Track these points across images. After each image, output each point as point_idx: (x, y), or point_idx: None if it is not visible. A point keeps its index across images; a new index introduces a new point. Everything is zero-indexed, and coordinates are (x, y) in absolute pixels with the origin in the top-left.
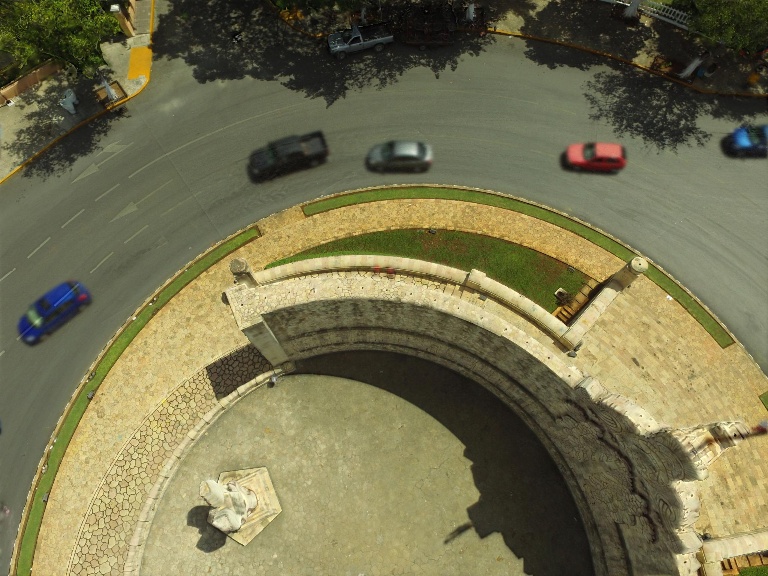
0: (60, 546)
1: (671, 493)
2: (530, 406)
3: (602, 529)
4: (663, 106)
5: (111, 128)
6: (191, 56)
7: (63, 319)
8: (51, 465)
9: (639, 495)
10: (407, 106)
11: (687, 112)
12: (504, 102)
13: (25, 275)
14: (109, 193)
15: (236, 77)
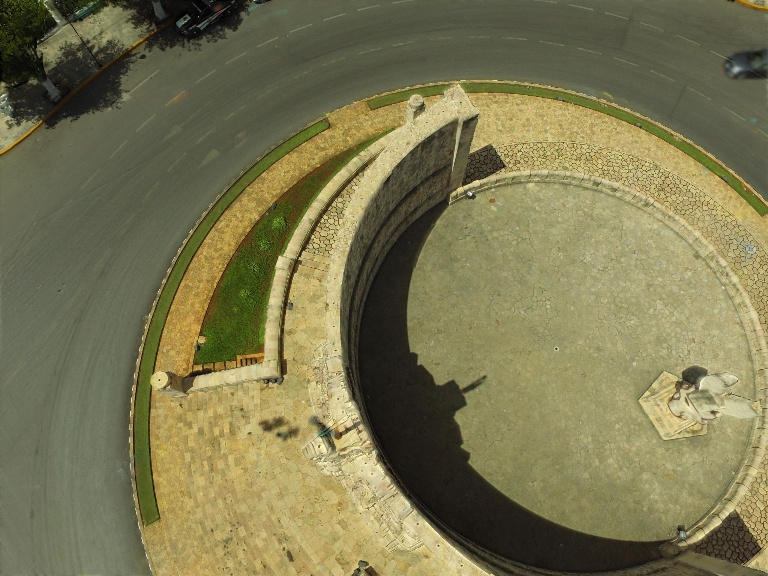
0: None
1: None
2: None
3: None
4: None
5: None
6: None
7: None
8: None
9: None
10: None
11: None
12: None
13: None
14: None
15: None
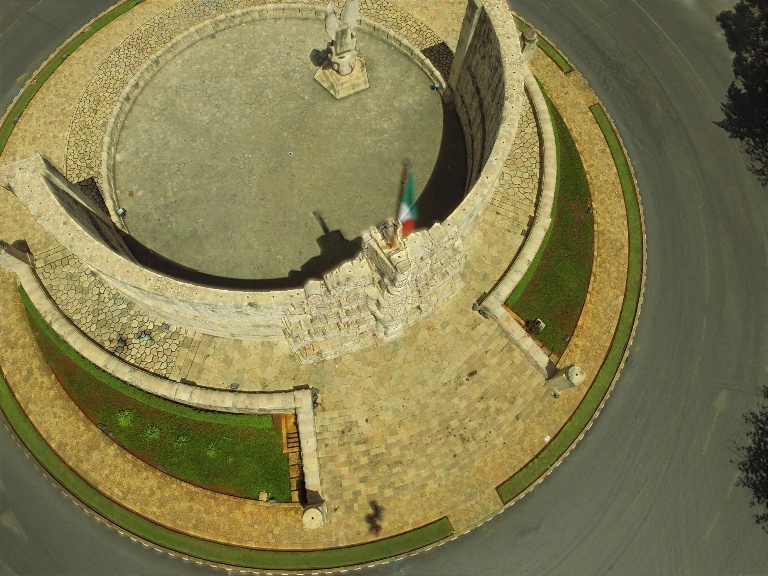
0: None
1: None
2: None
3: None
4: None
5: None
6: (746, 7)
7: None
8: None
9: None
10: (734, 194)
11: None
12: (764, 293)
13: None
14: None
15: (731, 44)
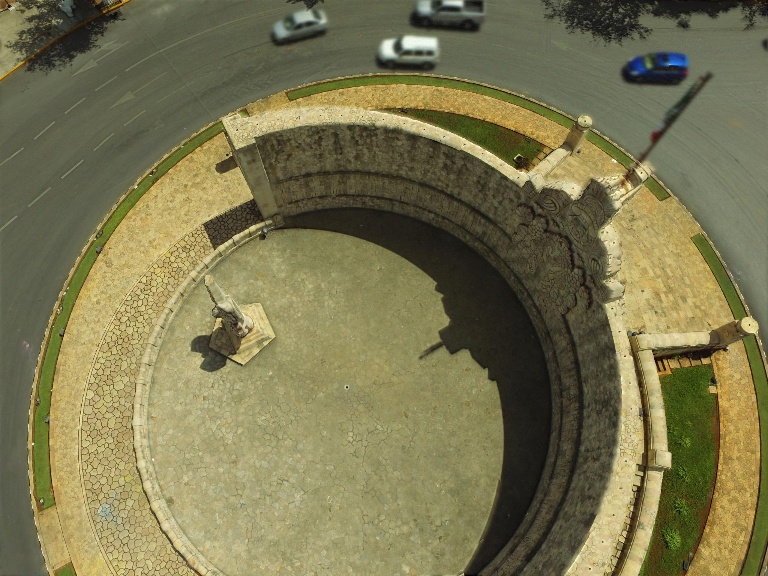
0: (77, 370)
1: (598, 245)
2: (491, 236)
3: (553, 331)
4: (610, 7)
5: (107, 29)
6: None
7: (70, 189)
8: (65, 307)
9: (576, 267)
10: (380, 9)
11: (631, 11)
12: (468, 5)
13: (33, 153)
14: (108, 84)
15: None
